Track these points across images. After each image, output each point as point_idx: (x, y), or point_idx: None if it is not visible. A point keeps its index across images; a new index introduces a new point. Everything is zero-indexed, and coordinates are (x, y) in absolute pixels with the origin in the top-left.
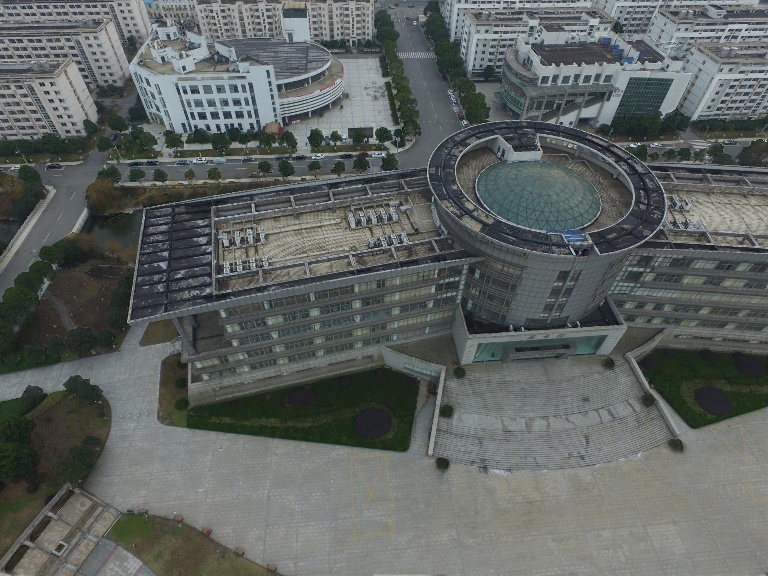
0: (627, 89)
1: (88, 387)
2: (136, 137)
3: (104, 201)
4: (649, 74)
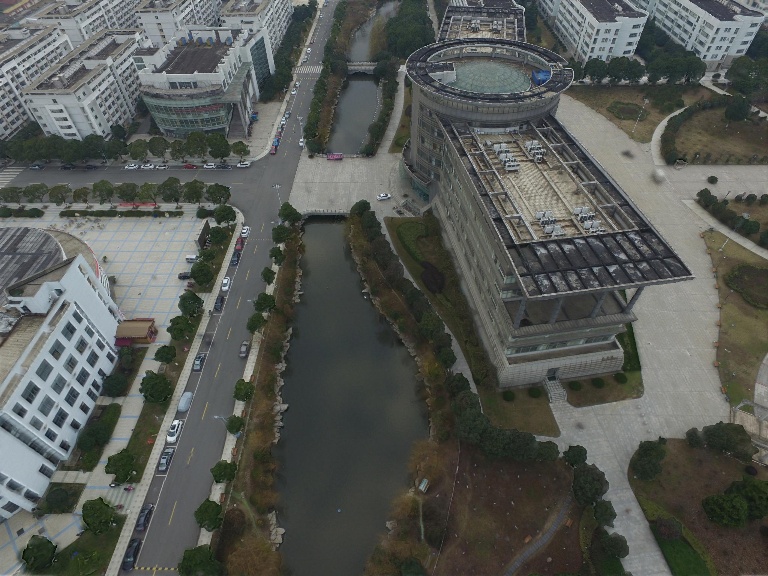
0: (252, 60)
1: (651, 446)
2: (50, 557)
3: (279, 556)
4: (254, 40)
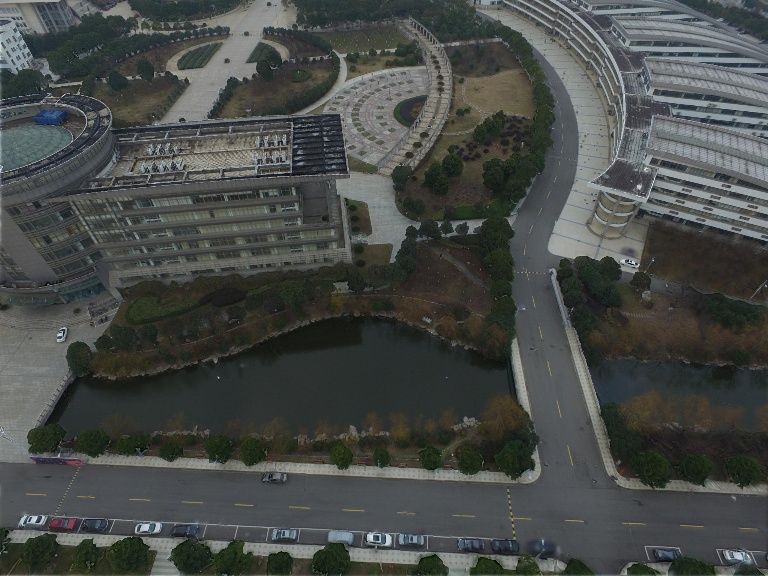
0: None
1: (408, 200)
2: None
3: None
4: None
